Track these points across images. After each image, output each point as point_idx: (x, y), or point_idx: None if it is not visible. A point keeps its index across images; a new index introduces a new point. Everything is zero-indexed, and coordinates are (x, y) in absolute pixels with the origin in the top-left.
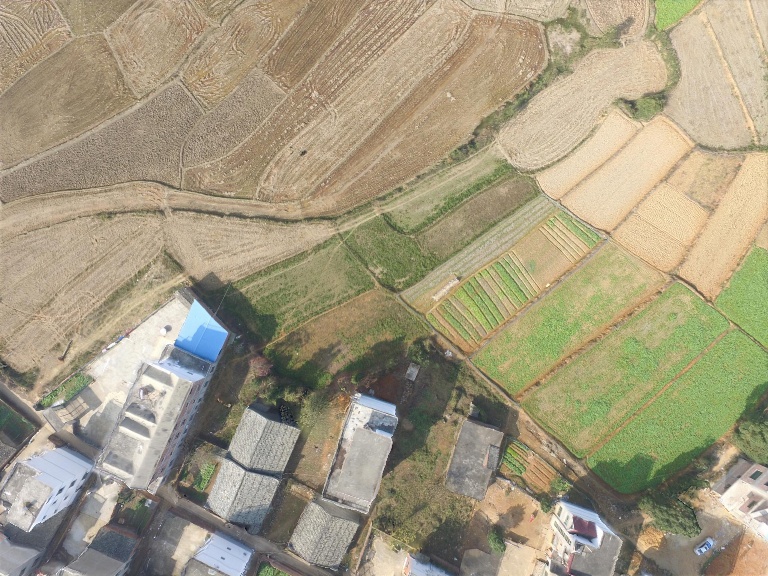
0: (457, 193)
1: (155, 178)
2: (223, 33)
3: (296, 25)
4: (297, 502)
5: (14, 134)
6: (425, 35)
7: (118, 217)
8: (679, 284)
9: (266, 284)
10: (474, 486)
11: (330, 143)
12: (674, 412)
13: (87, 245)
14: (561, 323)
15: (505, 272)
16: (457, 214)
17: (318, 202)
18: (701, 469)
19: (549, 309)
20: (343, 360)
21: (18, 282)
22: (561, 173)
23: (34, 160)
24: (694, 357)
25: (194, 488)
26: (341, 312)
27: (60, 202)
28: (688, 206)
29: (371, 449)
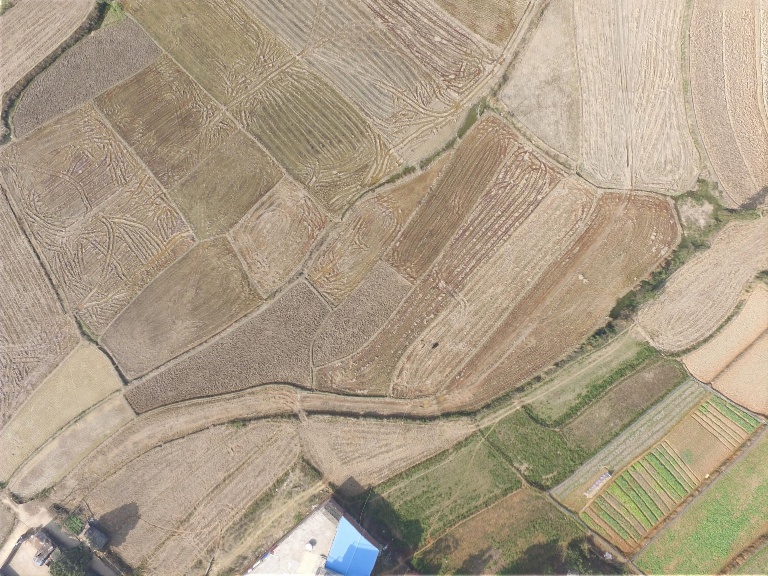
0: (599, 380)
1: (286, 379)
2: (345, 228)
3: (418, 215)
4: None
5: (144, 342)
6: (551, 217)
7: (253, 424)
8: None
9: (408, 487)
10: None
11: (462, 334)
12: None
13: (223, 455)
14: (727, 518)
15: (660, 464)
16: (602, 403)
17: (454, 396)
18: None
19: (712, 503)
20: (495, 566)
21: (156, 497)
22: (709, 355)
23: (165, 368)
24: None
25: None
26: (489, 514)
27: (193, 411)
28: None
29: None
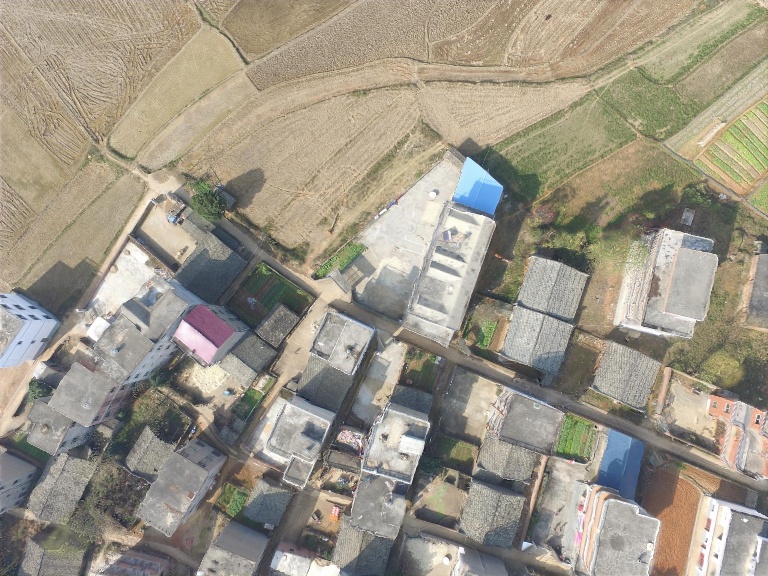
0: (710, 41)
1: (403, 55)
2: None
3: None
4: (585, 353)
5: (263, 26)
6: None
7: (372, 93)
8: None
9: (525, 145)
10: None
11: (574, 5)
12: None
13: (344, 122)
14: None
15: None
16: (714, 60)
17: (567, 63)
18: None
19: None
20: (612, 212)
21: (281, 162)
22: None
23: (285, 48)
24: None
25: (477, 346)
26: (605, 165)
27: (314, 84)
28: None
29: (697, 267)
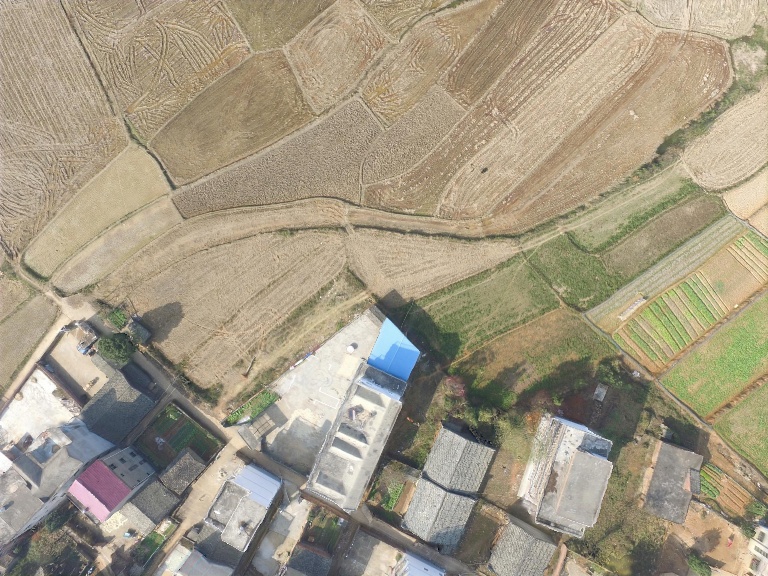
0: (641, 212)
1: (335, 194)
2: (402, 49)
3: (476, 42)
4: (487, 522)
5: (194, 149)
6: (607, 52)
7: (300, 233)
8: None
9: (449, 302)
10: (673, 509)
11: (511, 161)
12: None
13: (269, 261)
14: (752, 345)
15: (693, 292)
16: (643, 233)
17: (499, 220)
18: None
19: (739, 330)
20: (528, 379)
21: (200, 298)
22: (749, 193)
23: (214, 176)
24: None
25: (382, 507)
26: (526, 331)
27: (241, 218)
28: None
29: (591, 473)
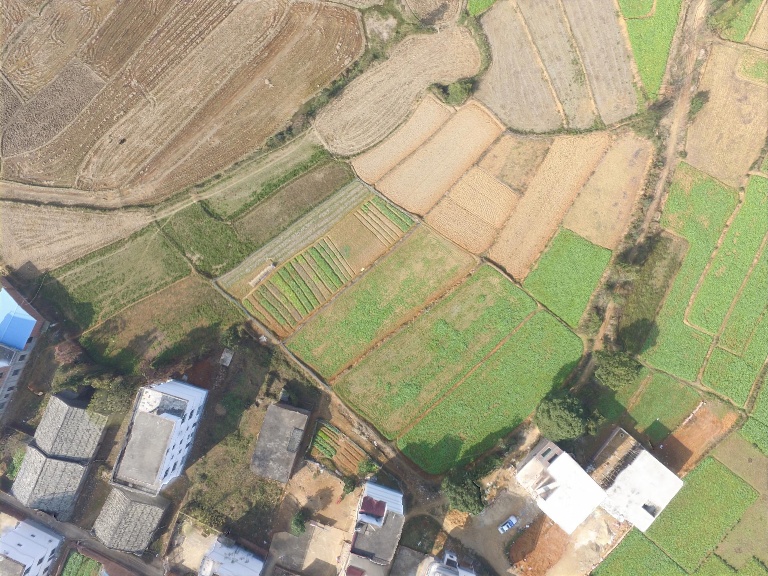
0: (274, 179)
1: None
2: (42, 22)
3: (115, 14)
4: (109, 489)
5: None
6: (243, 23)
7: None
8: (488, 266)
9: (83, 272)
10: (278, 469)
11: (149, 131)
12: (482, 393)
13: None
14: (374, 307)
15: (320, 257)
16: (273, 200)
17: (137, 190)
18: (504, 448)
19: (362, 293)
20: (159, 347)
21: None
22: (376, 158)
23: None
24: (503, 338)
25: (7, 477)
26: (157, 299)
27: None
28: (499, 189)
29: (153, 432)
